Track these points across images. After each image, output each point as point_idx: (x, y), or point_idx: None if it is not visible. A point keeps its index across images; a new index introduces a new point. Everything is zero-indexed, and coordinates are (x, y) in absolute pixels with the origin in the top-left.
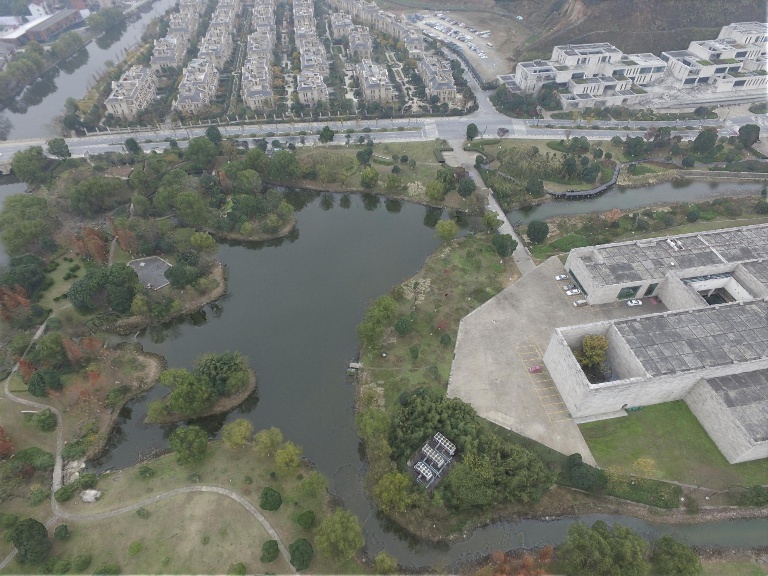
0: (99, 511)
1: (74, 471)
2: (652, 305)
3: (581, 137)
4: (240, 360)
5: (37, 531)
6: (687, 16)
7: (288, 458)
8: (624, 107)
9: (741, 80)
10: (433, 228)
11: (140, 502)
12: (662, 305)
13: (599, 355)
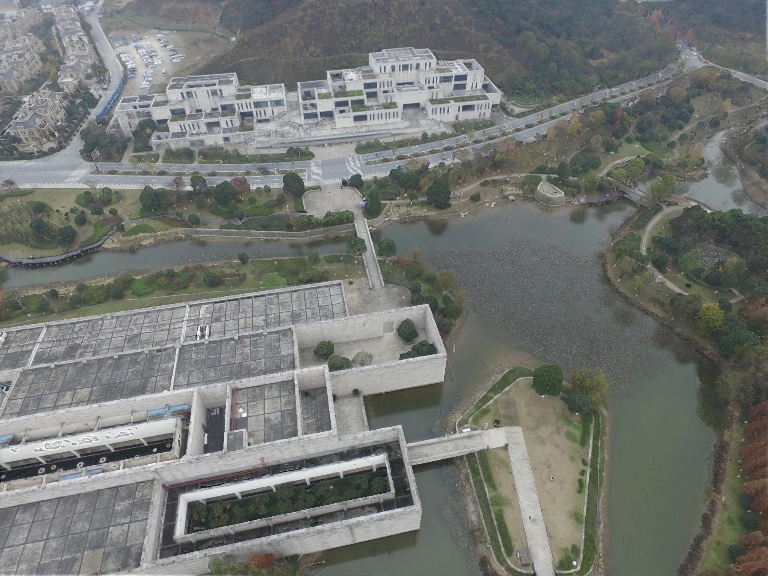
0: None
1: None
2: None
3: None
4: None
5: None
6: (349, 41)
7: None
8: (219, 147)
9: (360, 115)
10: None
11: None
12: None
13: None
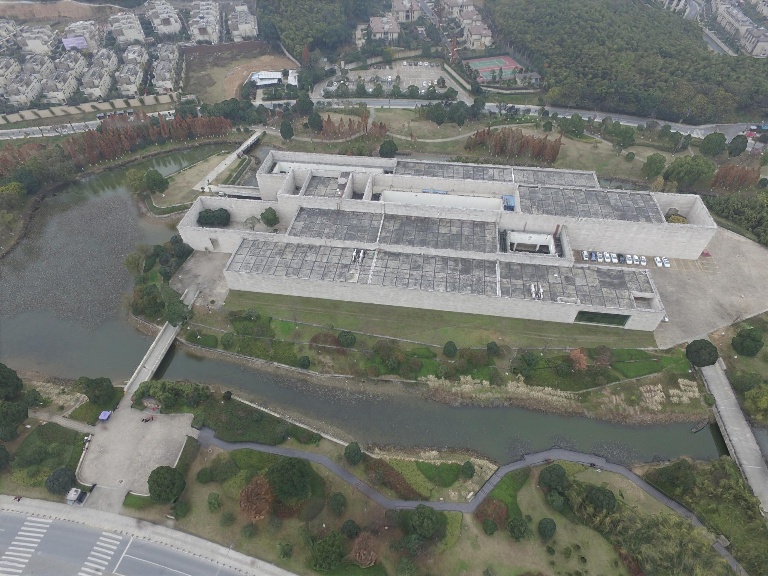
0: None
1: None
2: None
3: None
4: None
5: None
6: None
7: None
8: None
9: None
10: None
11: None
12: None
13: None
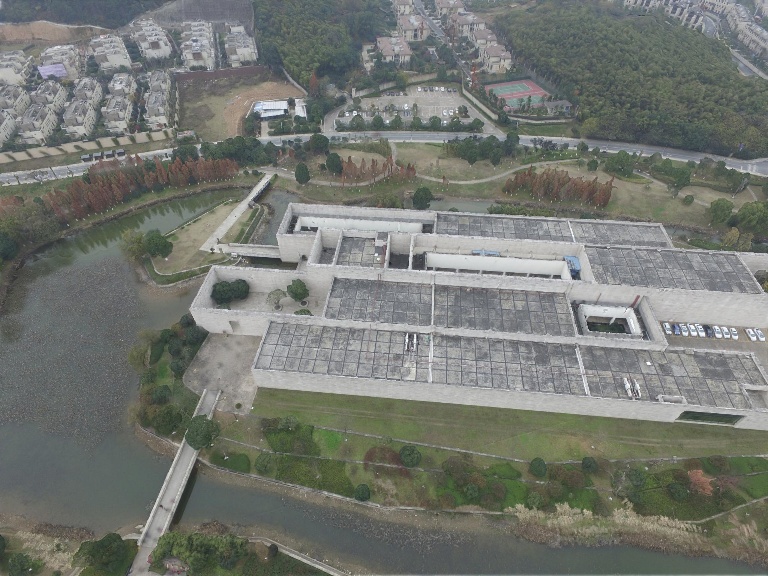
0: None
1: None
2: None
3: None
4: None
5: None
6: None
7: None
8: None
9: None
10: None
11: None
12: None
13: None
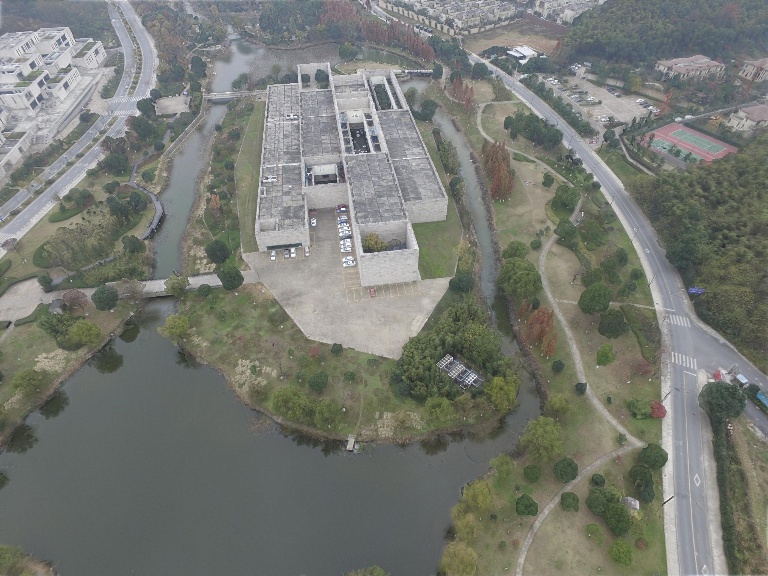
0: None
1: None
2: (317, 215)
3: (70, 192)
4: None
5: None
6: None
7: (486, 489)
8: (31, 154)
9: (64, 82)
10: (124, 363)
11: None
12: (318, 210)
13: (381, 242)
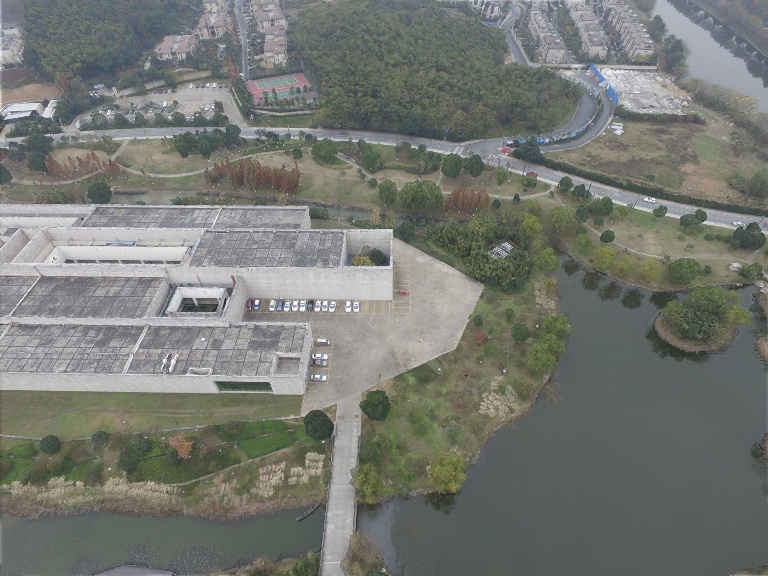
0: (721, 258)
1: (766, 288)
2: None
3: None
4: (680, 318)
5: (749, 238)
6: None
7: None
8: None
9: None
10: None
11: (697, 257)
12: None
13: None
